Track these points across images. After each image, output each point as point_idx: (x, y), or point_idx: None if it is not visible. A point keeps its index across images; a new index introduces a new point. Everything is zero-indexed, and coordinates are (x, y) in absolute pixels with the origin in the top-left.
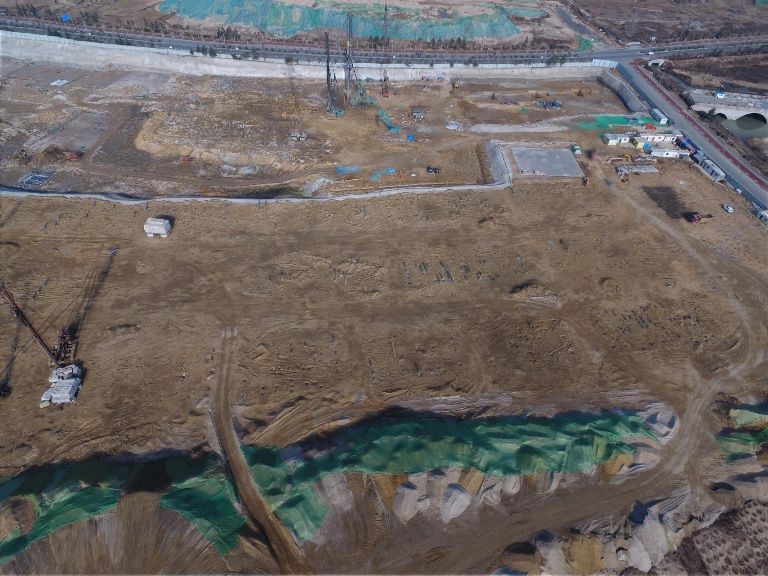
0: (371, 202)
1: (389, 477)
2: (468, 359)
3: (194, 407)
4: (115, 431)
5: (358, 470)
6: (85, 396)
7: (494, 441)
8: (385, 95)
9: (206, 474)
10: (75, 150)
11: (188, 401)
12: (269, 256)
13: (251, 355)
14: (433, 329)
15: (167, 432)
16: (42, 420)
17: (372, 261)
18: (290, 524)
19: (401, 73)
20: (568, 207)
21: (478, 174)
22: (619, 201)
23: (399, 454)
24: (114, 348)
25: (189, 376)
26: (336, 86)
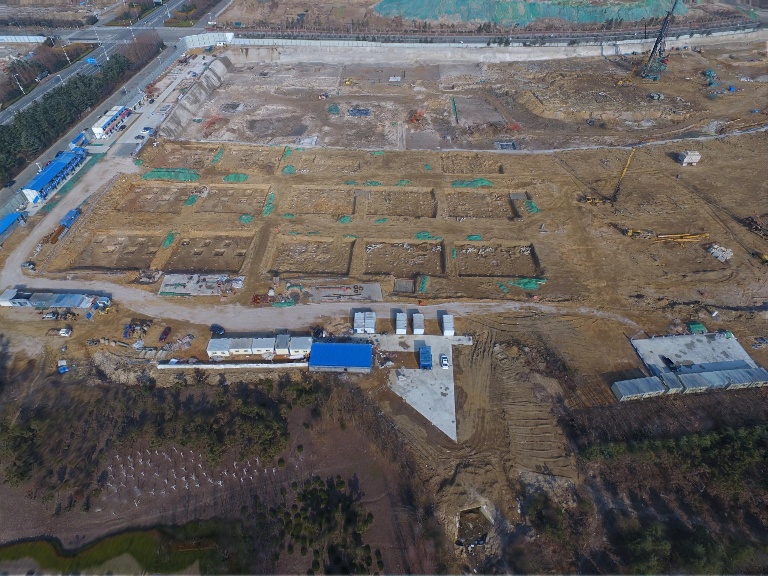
0: None
1: None
2: None
3: None
4: None
5: None
6: None
7: None
8: (666, 63)
9: None
10: (498, 124)
11: None
12: None
13: None
14: None
15: None
16: None
17: None
18: None
19: None
20: None
21: None
22: None
23: None
24: None
25: None
26: (618, 60)
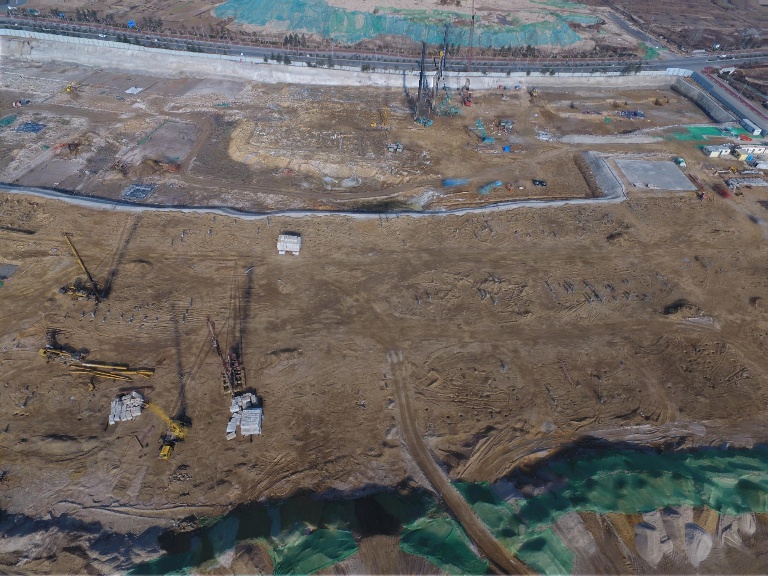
0: (492, 217)
1: (624, 517)
2: (646, 385)
3: (385, 438)
4: (312, 465)
5: (591, 509)
6: (270, 427)
7: (711, 475)
8: (467, 104)
9: (430, 513)
10: (170, 161)
11: (377, 432)
12: (408, 275)
13: (424, 381)
14: (599, 353)
15: (366, 466)
16: (234, 453)
17: (514, 280)
18: (541, 569)
19: (478, 81)
20: (691, 222)
21: (585, 187)
22: (740, 216)
23: (626, 491)
24: (283, 374)
25: (369, 404)
26: (415, 95)
